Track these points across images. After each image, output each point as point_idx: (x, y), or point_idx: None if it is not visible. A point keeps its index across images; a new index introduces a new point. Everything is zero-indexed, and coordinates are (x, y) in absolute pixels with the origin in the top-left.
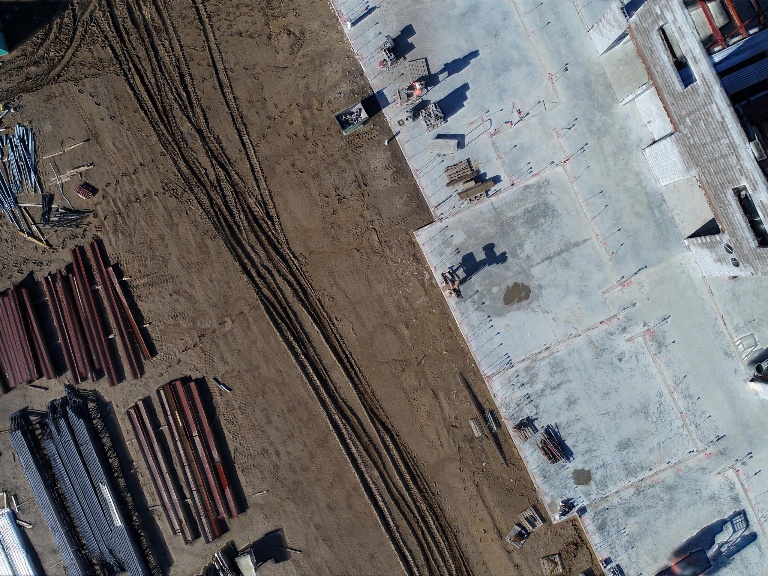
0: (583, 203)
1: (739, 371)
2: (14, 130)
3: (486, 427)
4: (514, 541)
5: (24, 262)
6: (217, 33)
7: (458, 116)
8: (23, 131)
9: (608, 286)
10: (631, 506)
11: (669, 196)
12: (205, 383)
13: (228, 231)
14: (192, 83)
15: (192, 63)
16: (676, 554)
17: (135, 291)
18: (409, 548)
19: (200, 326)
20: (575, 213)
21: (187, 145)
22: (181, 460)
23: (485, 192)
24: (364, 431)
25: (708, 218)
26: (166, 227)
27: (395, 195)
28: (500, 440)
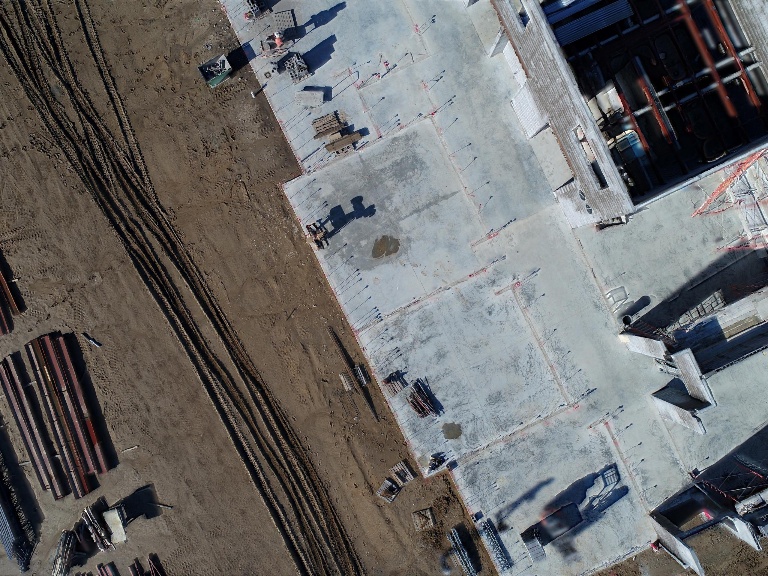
0: (451, 155)
1: (609, 324)
2: None
3: (356, 381)
4: (385, 496)
5: None
6: None
7: (325, 68)
8: None
9: (477, 239)
10: (502, 460)
11: (538, 148)
12: (75, 338)
13: (96, 185)
14: (59, 36)
15: (59, 16)
16: (547, 508)
17: (4, 246)
18: (280, 503)
19: (69, 281)
20: (443, 166)
21: (55, 99)
22: (50, 415)
23: (352, 144)
24: (234, 386)
25: None
26: (34, 181)
27: (263, 148)
28: (370, 394)
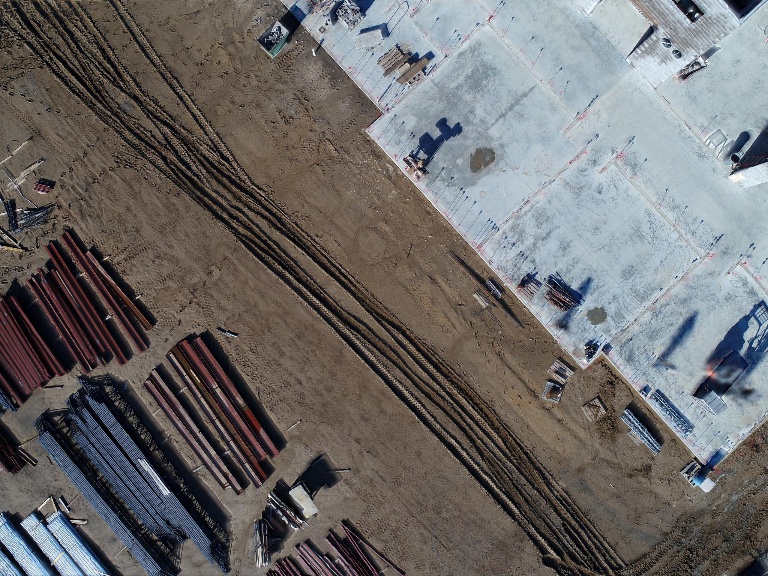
0: (518, 54)
1: (717, 169)
2: None
3: (491, 296)
4: (551, 397)
5: (5, 272)
6: None
7: (374, 7)
8: None
9: (566, 126)
10: (653, 330)
11: (598, 22)
12: (211, 335)
13: (189, 183)
14: (114, 54)
15: (108, 35)
16: (711, 363)
17: (118, 267)
18: (453, 435)
19: (190, 282)
20: (514, 66)
21: (126, 114)
22: (209, 415)
23: (422, 71)
24: (376, 335)
25: (642, 32)
26: (129, 198)
27: (337, 101)
28: (508, 305)
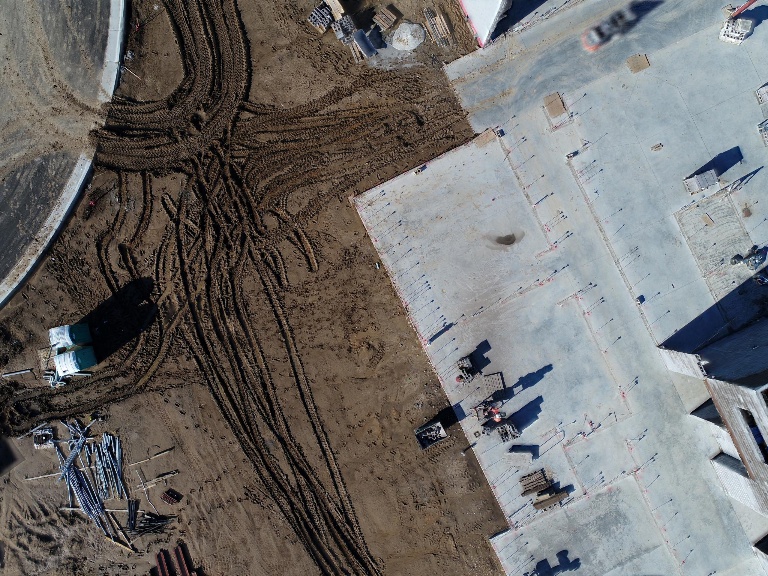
0: (653, 511)
1: None
2: (102, 438)
3: None
4: None
5: (110, 565)
6: (299, 345)
7: (532, 428)
8: (110, 439)
9: None
10: None
11: (737, 504)
12: None
13: (309, 536)
14: (274, 393)
15: (274, 373)
16: None
17: None
18: None
19: None
20: (646, 521)
21: (269, 452)
22: None
23: (559, 502)
24: None
25: None
26: (248, 532)
27: (471, 502)
28: None
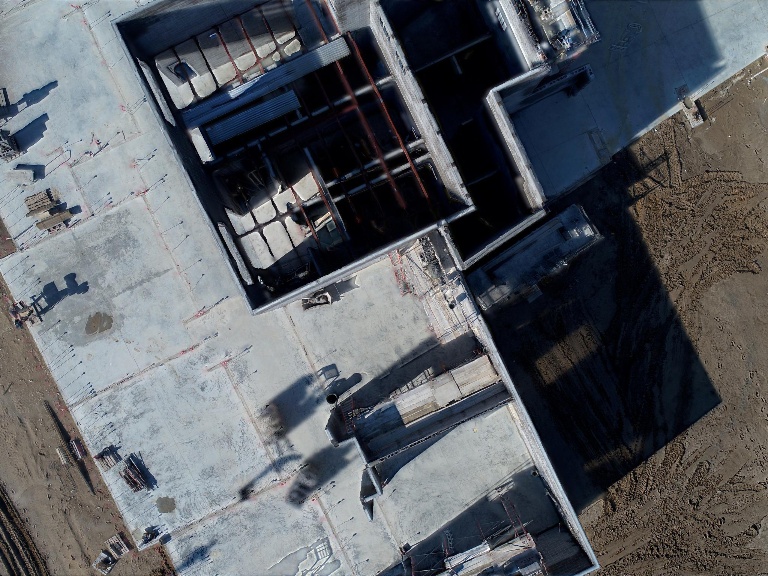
0: (163, 234)
1: (321, 401)
2: None
3: (70, 455)
4: (100, 568)
5: None
6: None
7: (37, 147)
8: None
9: (190, 316)
10: (215, 534)
11: (249, 227)
12: None
13: None
14: None
15: None
16: None
17: None
18: None
19: None
20: (156, 243)
21: None
22: None
23: (63, 222)
24: None
25: (288, 249)
26: None
27: None
28: (87, 468)
